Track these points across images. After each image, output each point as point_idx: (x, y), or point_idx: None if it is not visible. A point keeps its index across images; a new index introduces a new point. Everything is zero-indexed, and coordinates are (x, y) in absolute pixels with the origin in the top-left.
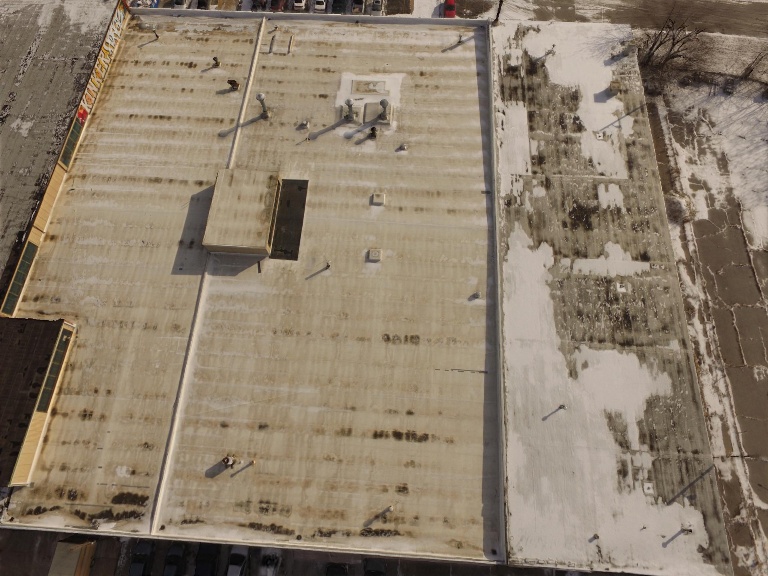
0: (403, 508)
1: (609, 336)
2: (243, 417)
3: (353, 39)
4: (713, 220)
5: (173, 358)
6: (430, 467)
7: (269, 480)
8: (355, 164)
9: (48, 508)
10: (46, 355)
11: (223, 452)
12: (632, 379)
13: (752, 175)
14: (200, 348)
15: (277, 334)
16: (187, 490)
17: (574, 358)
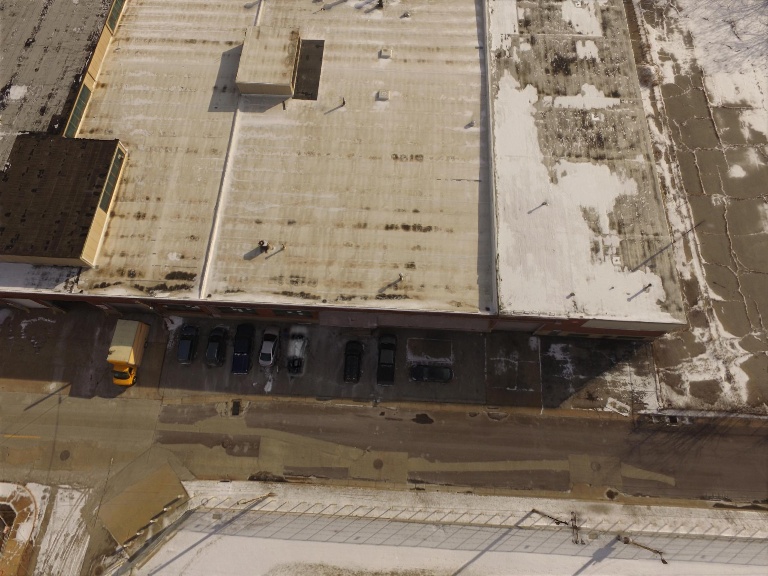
0: (411, 279)
1: (585, 152)
2: (274, 216)
3: None
4: (679, 84)
5: (212, 174)
6: (433, 250)
7: (298, 261)
8: (365, 28)
9: (112, 283)
10: (106, 165)
11: (258, 241)
12: (604, 183)
13: (714, 48)
14: (235, 166)
15: (301, 155)
16: (229, 269)
17: (555, 169)
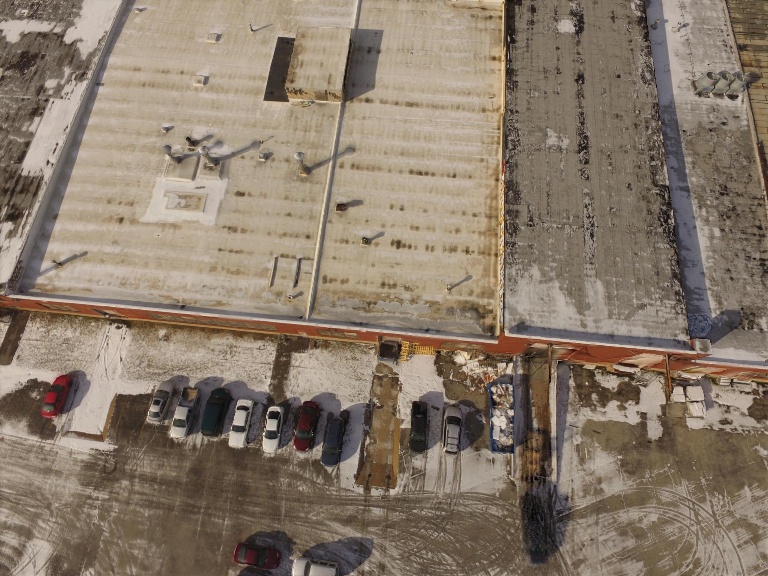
0: None
1: None
2: None
3: (193, 278)
4: None
5: None
6: None
7: None
8: (216, 115)
9: None
10: None
11: None
12: None
13: None
14: None
15: None
16: None
17: None
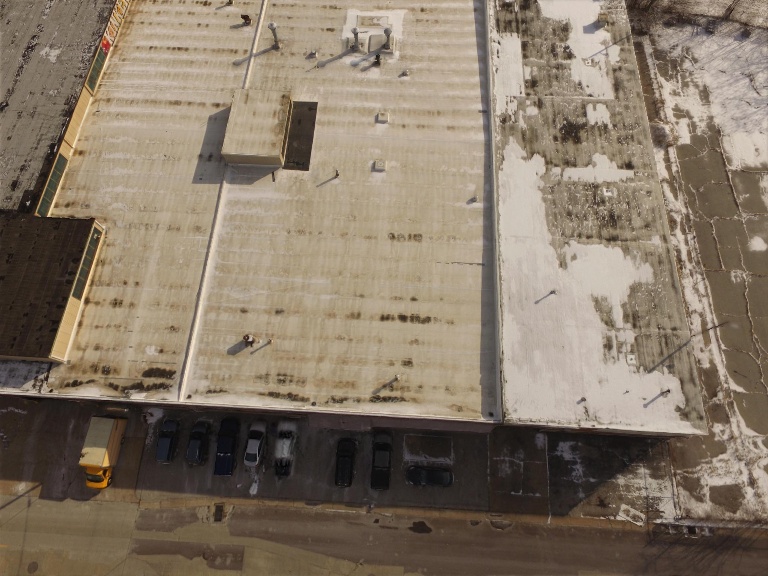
0: (408, 379)
1: (596, 233)
2: (261, 304)
3: None
4: (695, 144)
5: (195, 255)
6: (433, 344)
7: (286, 356)
8: (361, 88)
9: (84, 381)
10: (80, 248)
11: (243, 333)
12: (617, 269)
13: (731, 105)
14: (220, 246)
15: (291, 234)
16: (211, 365)
17: (564, 251)
